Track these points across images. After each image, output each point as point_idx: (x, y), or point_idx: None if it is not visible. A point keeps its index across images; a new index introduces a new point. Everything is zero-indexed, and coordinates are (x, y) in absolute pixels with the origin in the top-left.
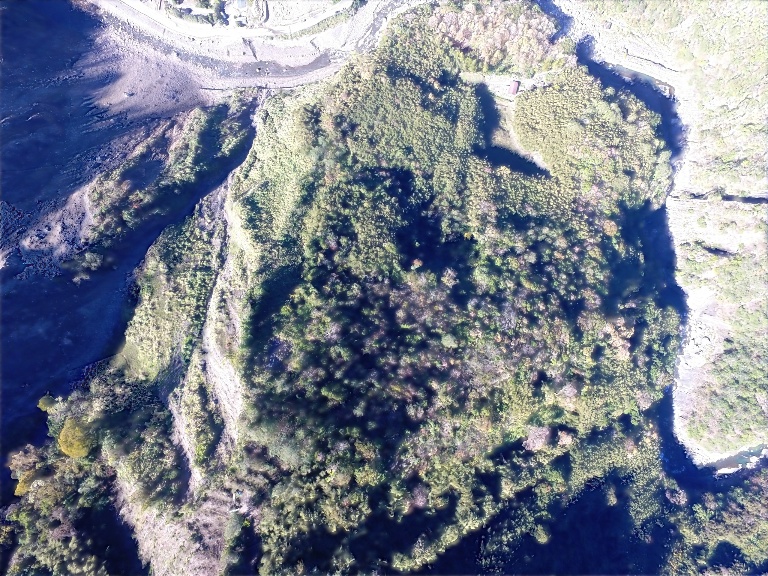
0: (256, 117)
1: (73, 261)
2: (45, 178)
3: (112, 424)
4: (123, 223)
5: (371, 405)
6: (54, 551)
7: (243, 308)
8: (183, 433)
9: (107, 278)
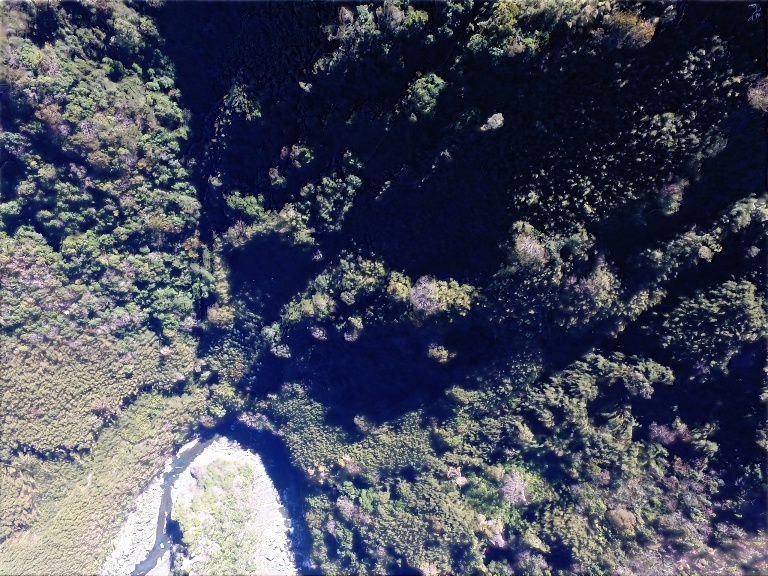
0: None
1: None
2: None
3: None
4: None
5: None
6: None
7: None
8: None
9: None
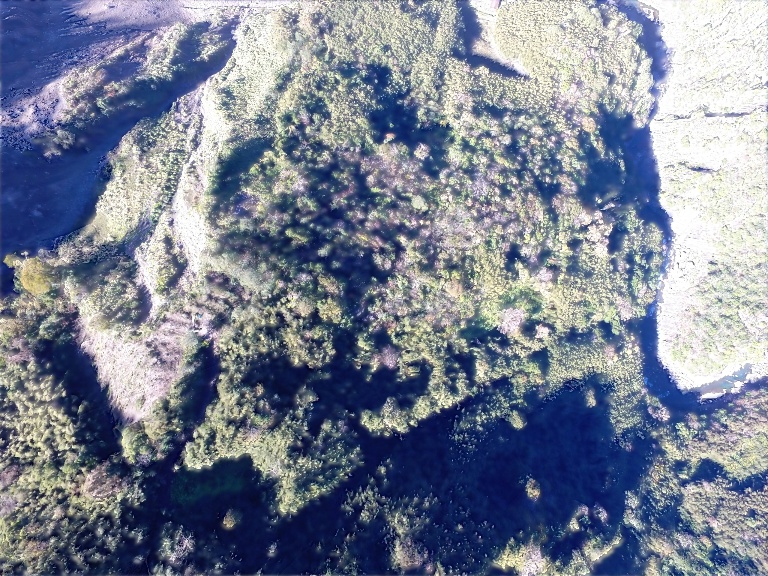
0: (237, 31)
1: (45, 138)
2: (20, 70)
3: (76, 271)
4: (97, 110)
5: (336, 249)
6: (12, 373)
7: (210, 160)
8: (147, 275)
9: (80, 160)
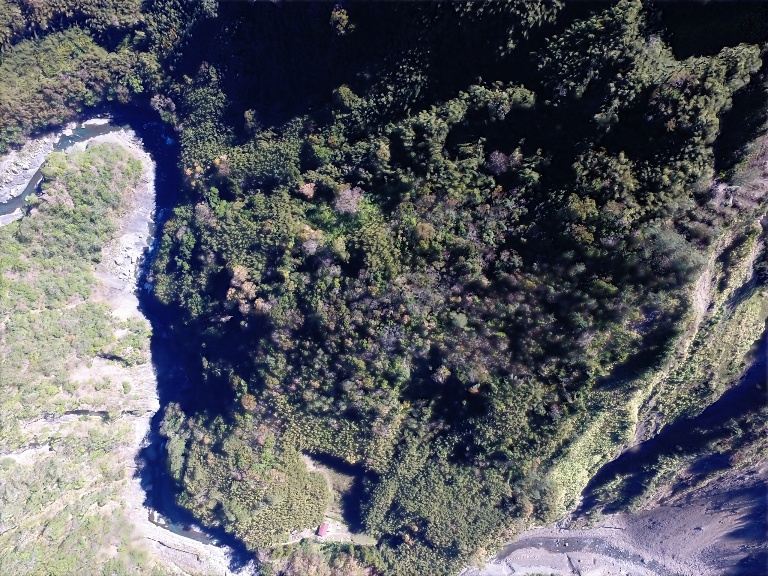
0: None
1: None
2: None
3: None
4: (742, 426)
5: None
6: None
7: None
8: None
9: (766, 377)
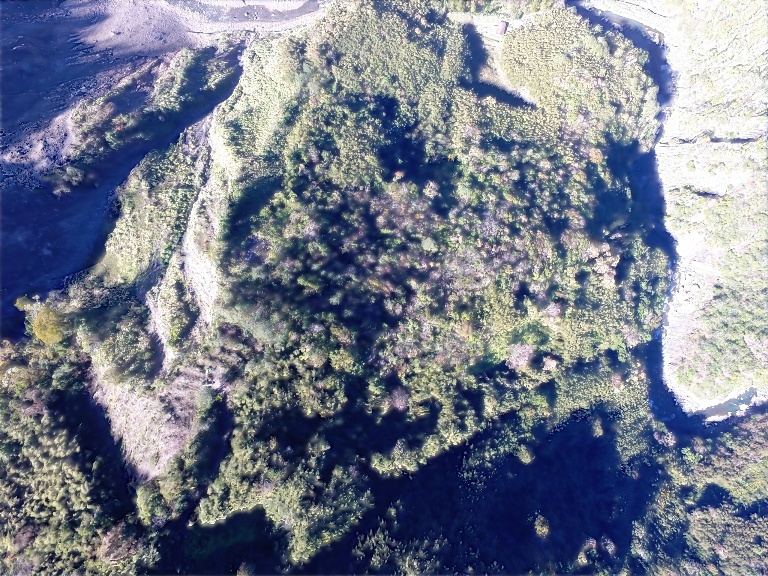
0: (243, 57)
1: (54, 175)
2: (28, 103)
3: (88, 317)
4: (106, 144)
5: (348, 296)
6: (26, 427)
7: (221, 205)
8: (159, 323)
9: (89, 196)
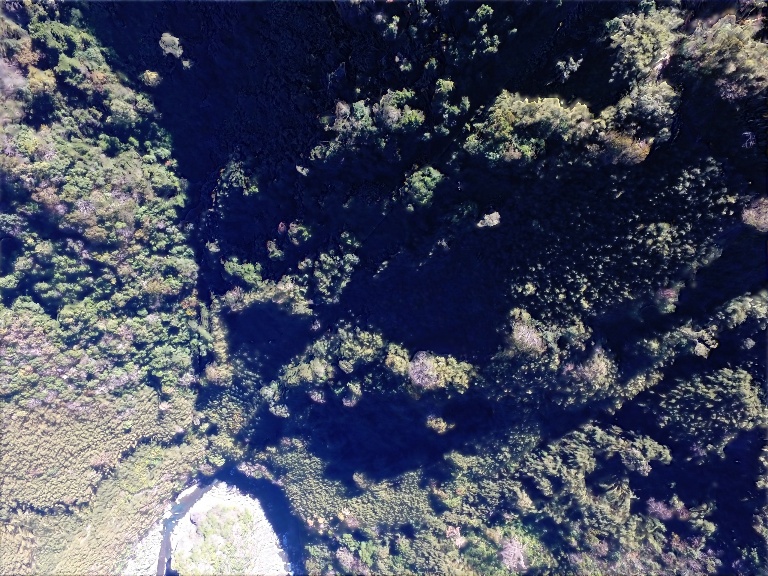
0: None
1: None
2: None
3: None
4: None
5: None
6: None
7: None
8: None
9: None
